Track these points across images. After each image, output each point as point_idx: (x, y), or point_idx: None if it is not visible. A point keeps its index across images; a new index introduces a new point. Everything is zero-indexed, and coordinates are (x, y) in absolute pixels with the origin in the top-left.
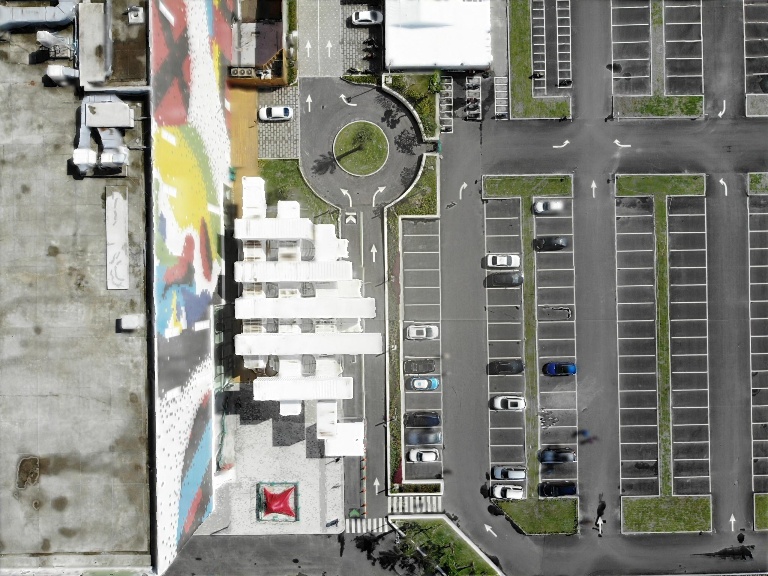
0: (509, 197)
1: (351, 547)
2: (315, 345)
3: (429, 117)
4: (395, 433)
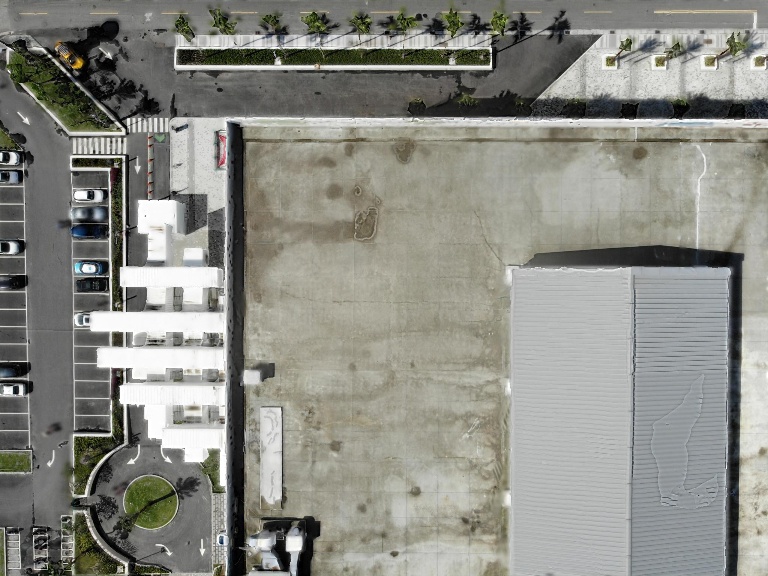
0: (6, 452)
1: (165, 104)
2: (156, 322)
3: (82, 533)
4: (118, 219)
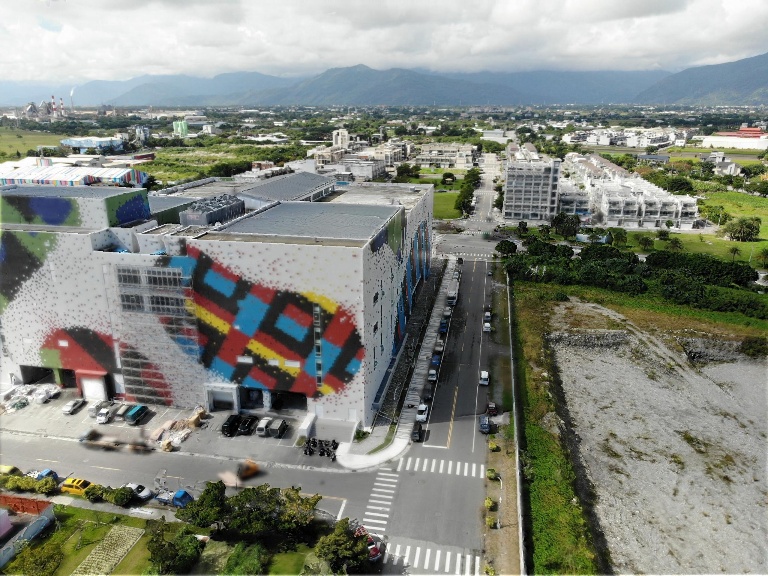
0: None
1: None
2: None
3: None
4: None
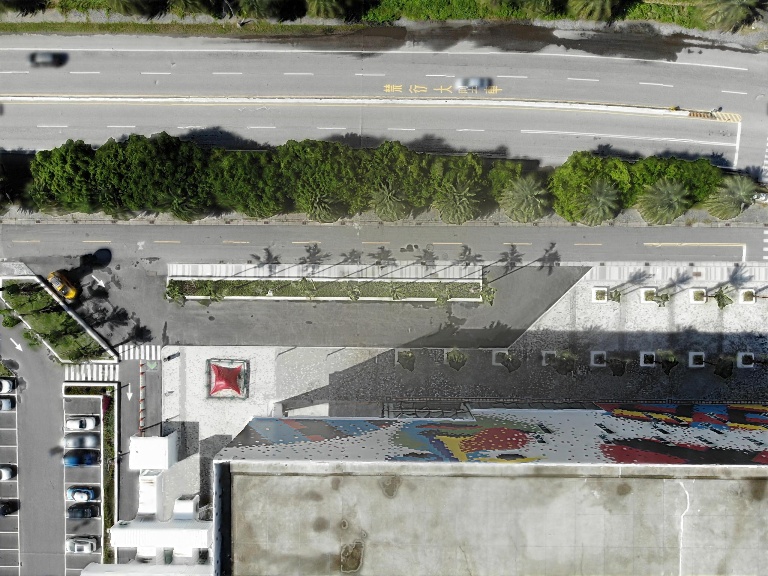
0: None
1: (157, 331)
2: None
3: None
4: (109, 447)
